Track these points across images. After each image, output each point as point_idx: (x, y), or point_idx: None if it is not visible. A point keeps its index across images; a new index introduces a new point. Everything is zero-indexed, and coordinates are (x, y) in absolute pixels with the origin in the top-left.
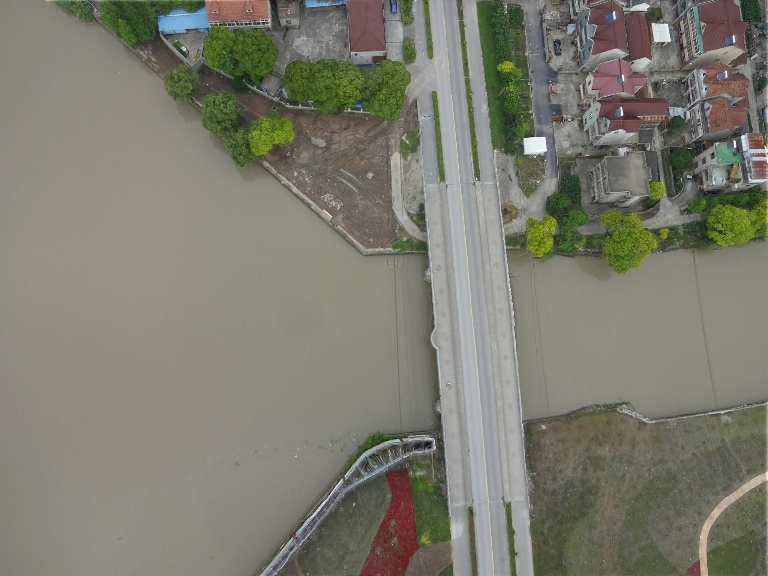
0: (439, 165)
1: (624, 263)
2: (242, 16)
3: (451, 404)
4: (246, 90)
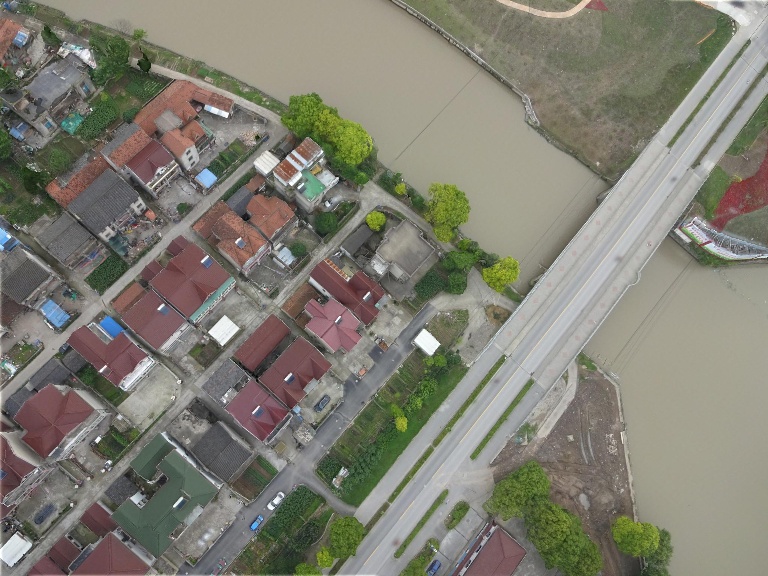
0: (524, 395)
1: None
2: None
3: (657, 233)
4: None
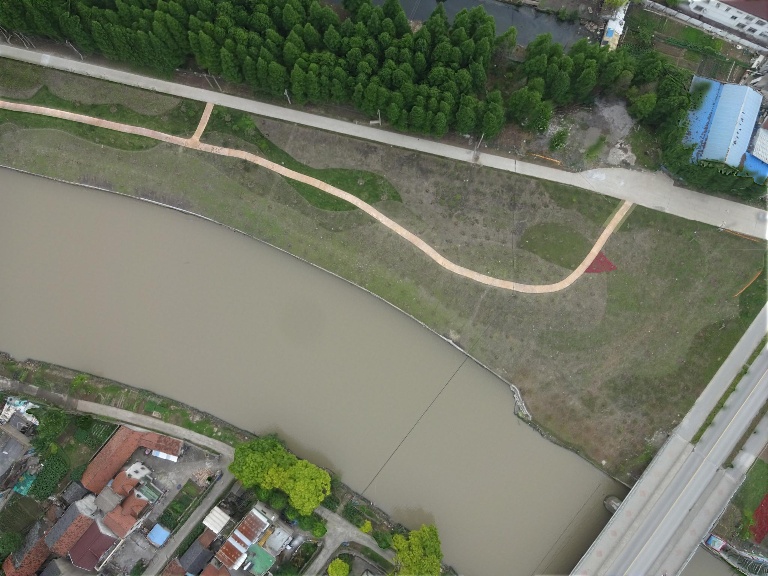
0: None
1: (435, 543)
2: None
3: (674, 559)
4: None
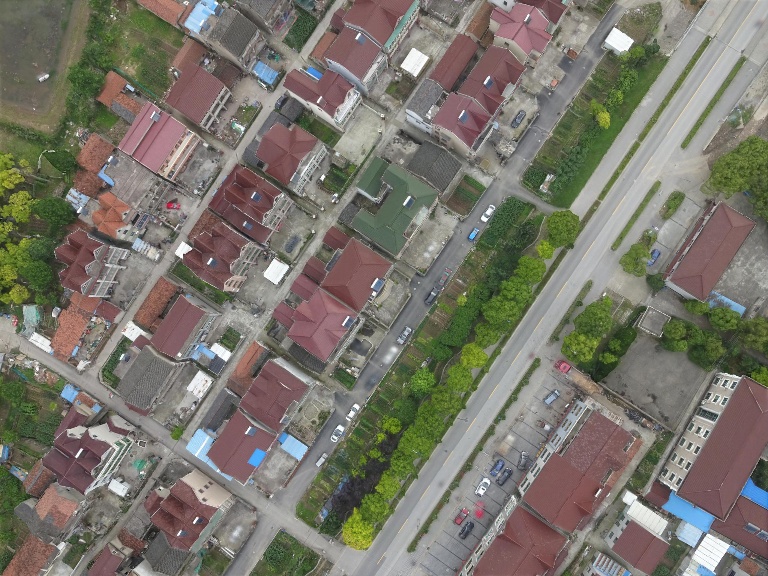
0: None
1: None
2: None
3: None
4: None
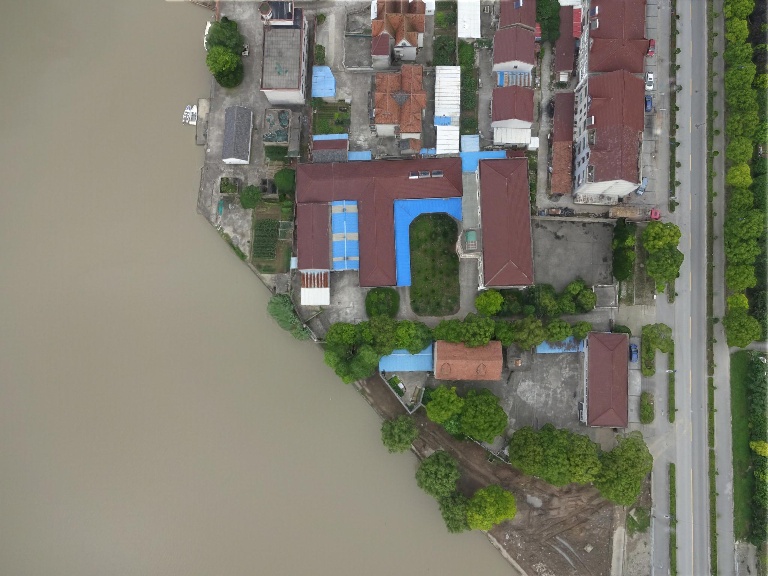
0: (671, 556)
1: None
2: (472, 376)
3: None
4: (463, 438)
